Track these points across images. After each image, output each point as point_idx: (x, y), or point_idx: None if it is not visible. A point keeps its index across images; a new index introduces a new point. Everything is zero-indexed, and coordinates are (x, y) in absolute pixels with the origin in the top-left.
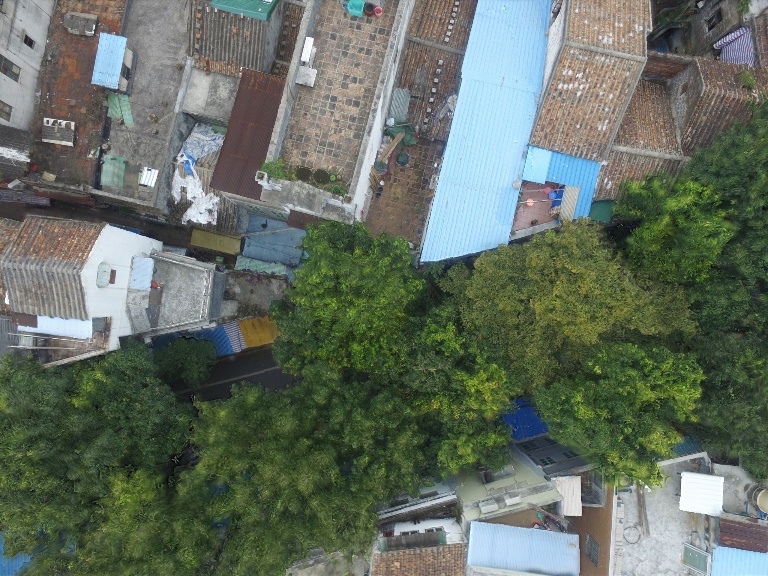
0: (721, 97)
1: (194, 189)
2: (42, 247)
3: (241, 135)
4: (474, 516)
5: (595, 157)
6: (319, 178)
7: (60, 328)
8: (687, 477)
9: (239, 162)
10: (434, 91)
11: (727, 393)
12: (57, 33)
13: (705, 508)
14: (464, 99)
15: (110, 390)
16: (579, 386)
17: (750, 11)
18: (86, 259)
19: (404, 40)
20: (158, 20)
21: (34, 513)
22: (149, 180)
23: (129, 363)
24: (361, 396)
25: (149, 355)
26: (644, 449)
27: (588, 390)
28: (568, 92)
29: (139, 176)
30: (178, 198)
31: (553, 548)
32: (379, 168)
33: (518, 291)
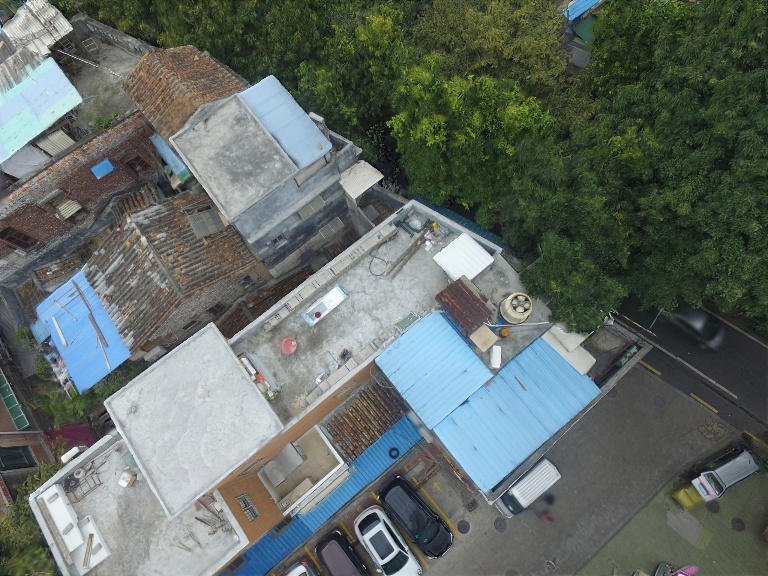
0: None
1: None
2: None
3: None
4: None
5: None
6: None
7: None
8: (465, 238)
9: None
10: None
11: None
12: None
13: (455, 271)
14: None
15: None
16: None
17: None
18: None
19: None
20: None
21: None
22: None
23: None
24: None
25: None
26: None
27: None
28: None
29: None
30: None
31: (305, 136)
32: None
33: None
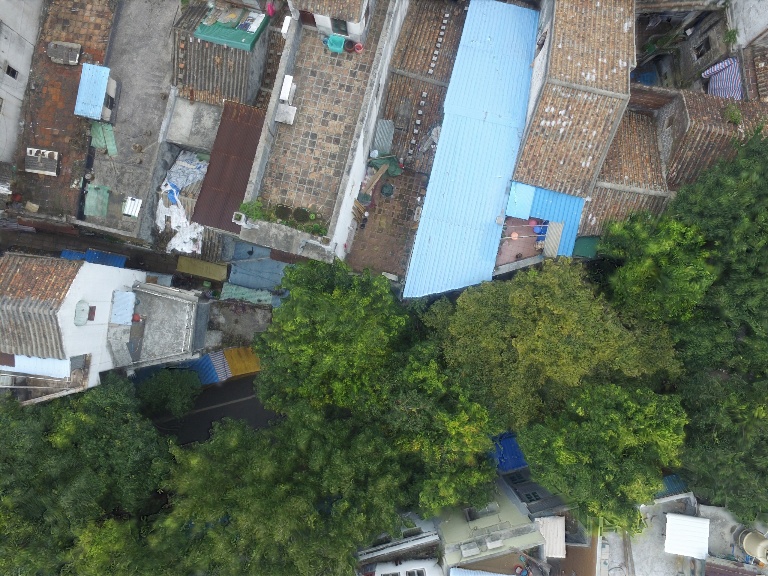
0: (706, 133)
1: (178, 218)
2: (19, 286)
3: (223, 168)
4: (455, 560)
5: (579, 193)
6: (298, 217)
7: (37, 367)
8: (672, 519)
9: (221, 195)
10: (418, 123)
11: (711, 437)
12: (41, 62)
13: (691, 550)
14: (447, 134)
15: (89, 427)
16: (563, 426)
17: (737, 42)
18: (63, 299)
19: (387, 72)
20: (142, 49)
21: (10, 556)
22: (133, 210)
23: (109, 400)
24: (342, 434)
25: (130, 389)
26: (625, 497)
27: (571, 432)
28: (551, 129)
29: (123, 206)
30: (162, 227)
31: None
32: (363, 200)
33: (501, 329)
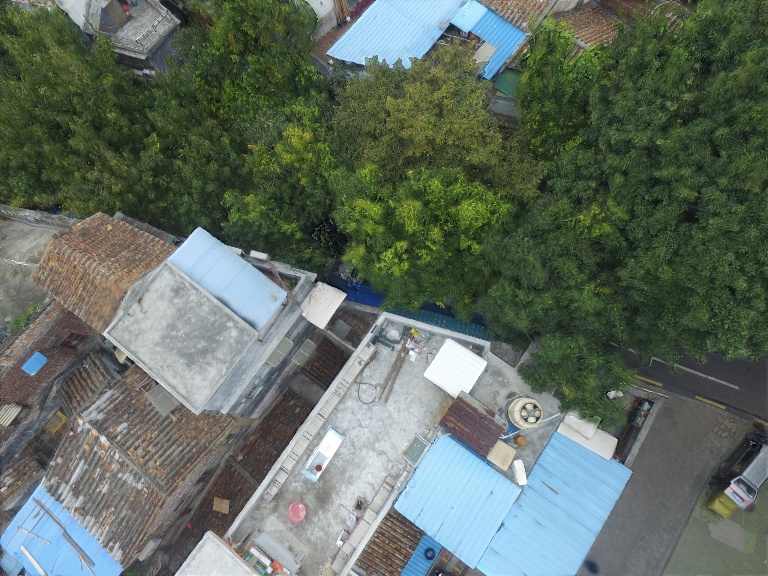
0: (671, 21)
1: None
2: None
3: None
4: None
5: (524, 27)
6: None
7: None
8: (450, 345)
9: None
10: None
11: None
12: None
13: (450, 385)
14: None
15: None
16: None
17: None
18: None
19: None
20: None
21: None
22: None
23: None
24: None
25: None
26: None
27: None
28: None
29: None
30: None
31: (254, 290)
32: None
33: None
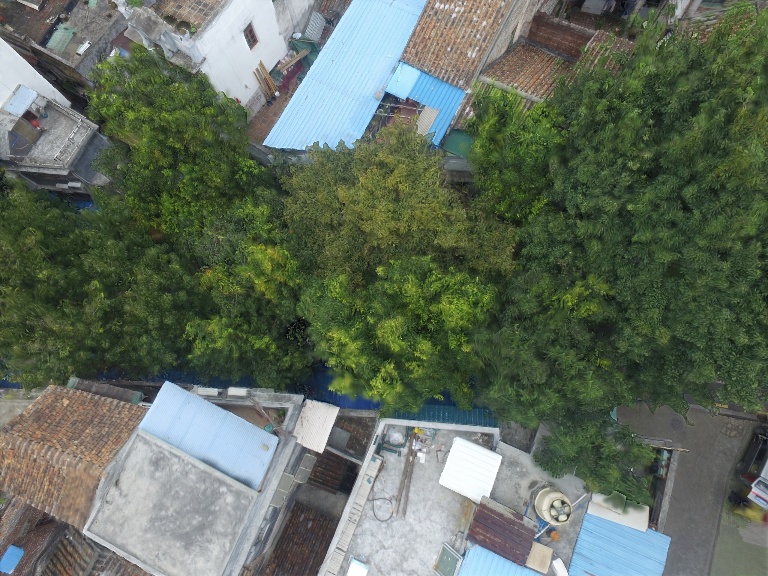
0: None
1: None
2: None
3: None
4: None
5: (462, 85)
6: (180, 27)
7: None
8: (459, 444)
9: None
10: None
11: (511, 329)
12: None
13: (469, 489)
14: (353, 10)
15: None
16: None
17: (675, 14)
18: None
19: None
20: None
21: None
22: None
23: None
24: None
25: None
26: (375, 343)
27: None
28: (443, 12)
29: (79, 47)
30: None
31: (242, 442)
32: (275, 75)
33: None
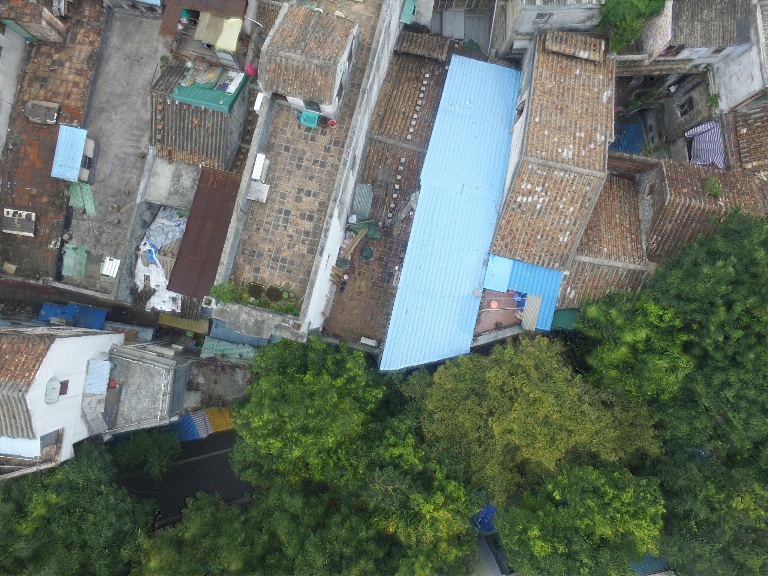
0: (686, 206)
1: (157, 277)
2: None
3: (199, 235)
4: None
5: (557, 266)
6: (271, 296)
7: (8, 446)
8: None
9: (197, 263)
10: (397, 187)
11: (689, 524)
12: (19, 121)
13: None
14: (423, 206)
15: (62, 501)
16: (540, 505)
17: (719, 107)
18: (33, 380)
19: (365, 139)
20: (121, 107)
21: None
22: (111, 270)
23: (82, 474)
24: (318, 511)
25: (106, 458)
26: None
27: (547, 516)
28: (527, 205)
29: (101, 266)
30: (141, 286)
31: None
32: (342, 264)
33: (478, 404)
